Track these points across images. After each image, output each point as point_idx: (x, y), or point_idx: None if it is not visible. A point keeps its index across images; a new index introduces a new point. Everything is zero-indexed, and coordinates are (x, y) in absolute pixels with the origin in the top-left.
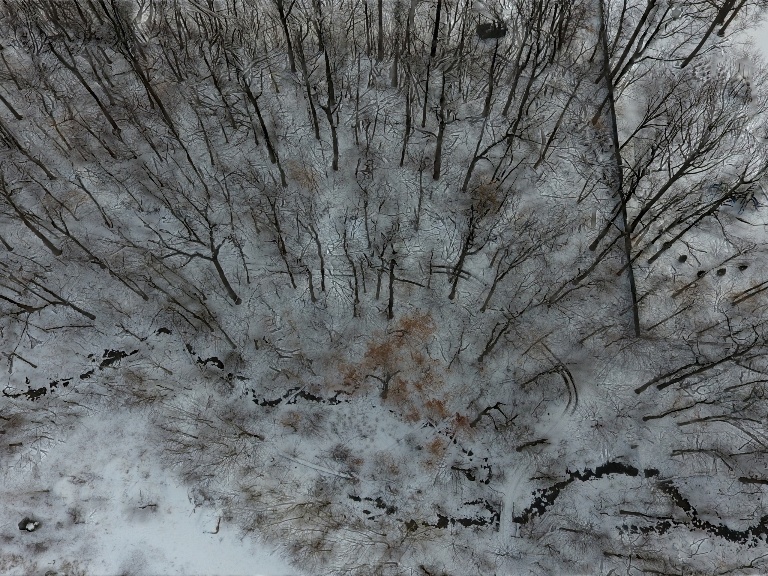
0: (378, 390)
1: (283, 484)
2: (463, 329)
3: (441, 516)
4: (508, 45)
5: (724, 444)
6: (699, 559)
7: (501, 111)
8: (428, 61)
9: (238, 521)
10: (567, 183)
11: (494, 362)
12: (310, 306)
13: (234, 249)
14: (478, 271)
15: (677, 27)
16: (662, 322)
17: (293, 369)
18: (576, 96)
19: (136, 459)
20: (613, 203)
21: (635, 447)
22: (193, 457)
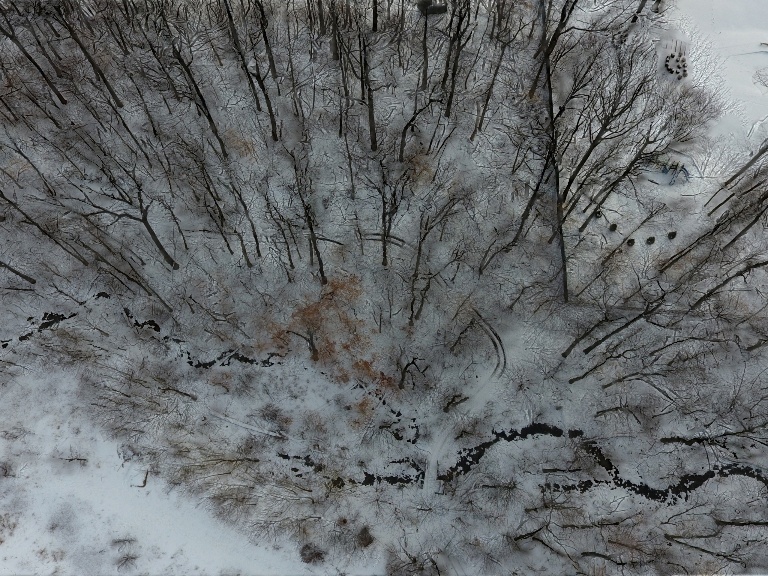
0: (309, 352)
1: (213, 442)
2: (390, 291)
3: (368, 474)
4: (448, 20)
5: (647, 406)
6: (618, 516)
7: (440, 84)
8: (369, 35)
9: (165, 475)
10: (502, 154)
11: (425, 326)
12: (246, 271)
13: (165, 211)
14: (412, 239)
15: (607, 0)
16: (587, 287)
17: (226, 331)
18: (515, 70)
19: (68, 416)
20: (546, 173)
21: (559, 408)
22: (124, 414)
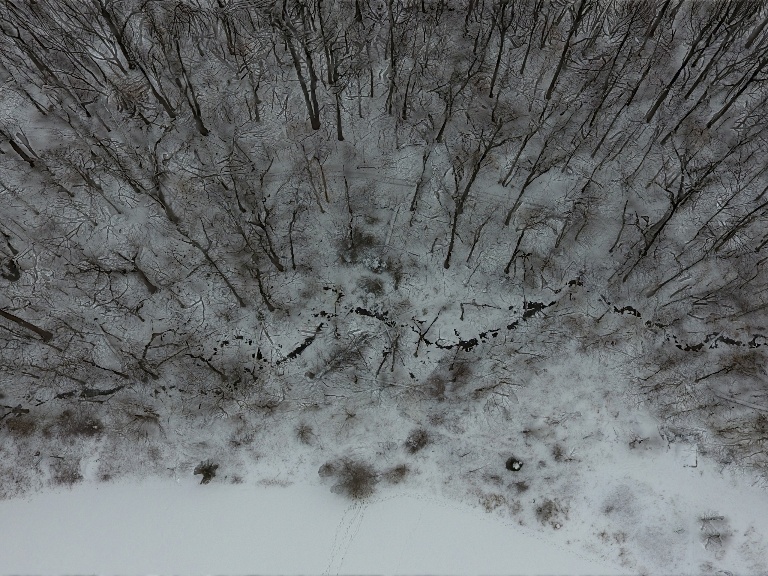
0: None
1: (731, 422)
2: None
3: None
4: None
5: None
6: None
7: None
8: None
9: (712, 455)
10: None
11: None
12: (712, 256)
13: None
14: None
15: None
16: None
17: None
18: None
19: (602, 400)
20: None
21: None
22: None
